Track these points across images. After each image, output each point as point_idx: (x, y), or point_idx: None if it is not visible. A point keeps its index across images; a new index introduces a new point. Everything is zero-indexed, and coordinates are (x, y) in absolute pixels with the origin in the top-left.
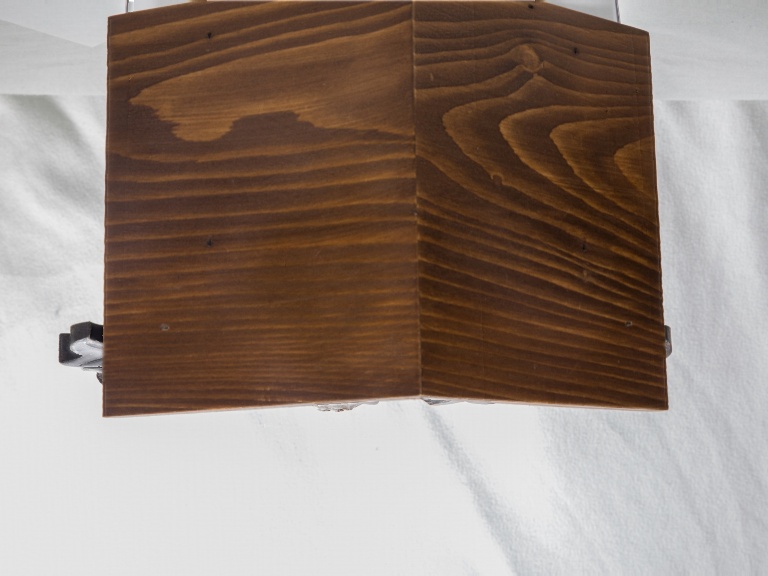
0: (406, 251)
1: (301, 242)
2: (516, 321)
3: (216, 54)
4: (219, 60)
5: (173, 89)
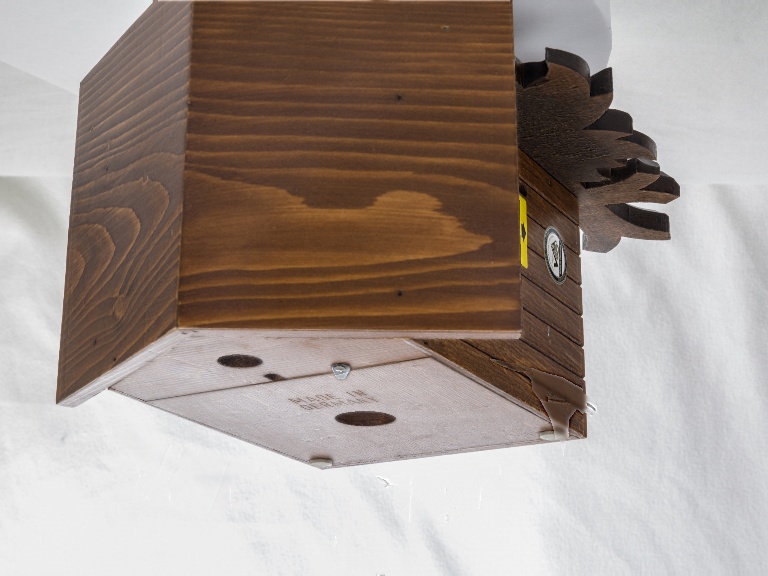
0: (200, 72)
1: (303, 89)
2: (145, 69)
3: (392, 273)
4: (389, 267)
5: (441, 245)
